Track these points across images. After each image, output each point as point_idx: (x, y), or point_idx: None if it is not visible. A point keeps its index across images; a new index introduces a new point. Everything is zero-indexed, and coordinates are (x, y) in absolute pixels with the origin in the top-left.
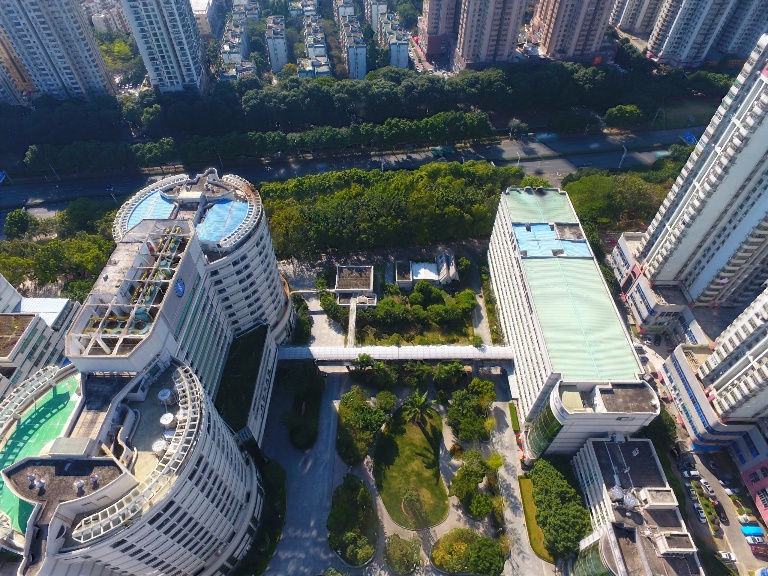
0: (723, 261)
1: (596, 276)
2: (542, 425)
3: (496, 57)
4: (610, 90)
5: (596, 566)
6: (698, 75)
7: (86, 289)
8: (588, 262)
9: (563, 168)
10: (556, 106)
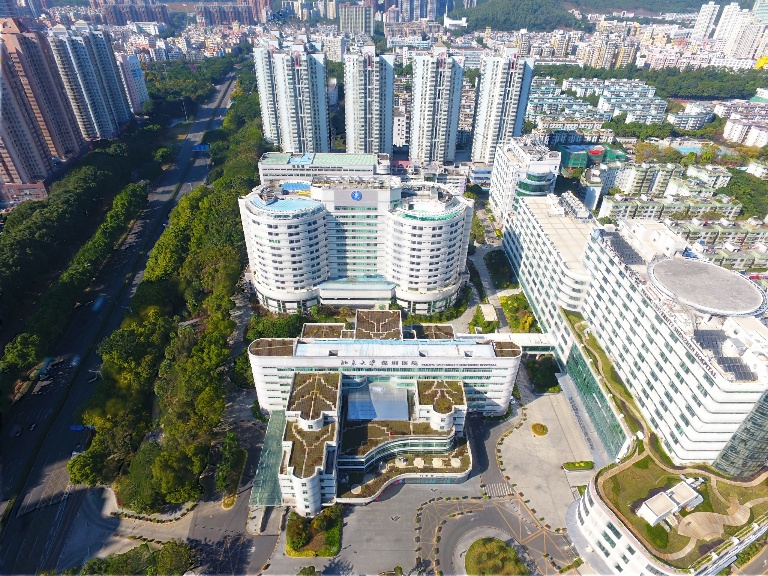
0: (325, 134)
1: None
2: None
3: (52, 169)
4: (133, 152)
5: None
6: (140, 131)
7: (247, 359)
8: None
9: (193, 185)
10: (125, 174)
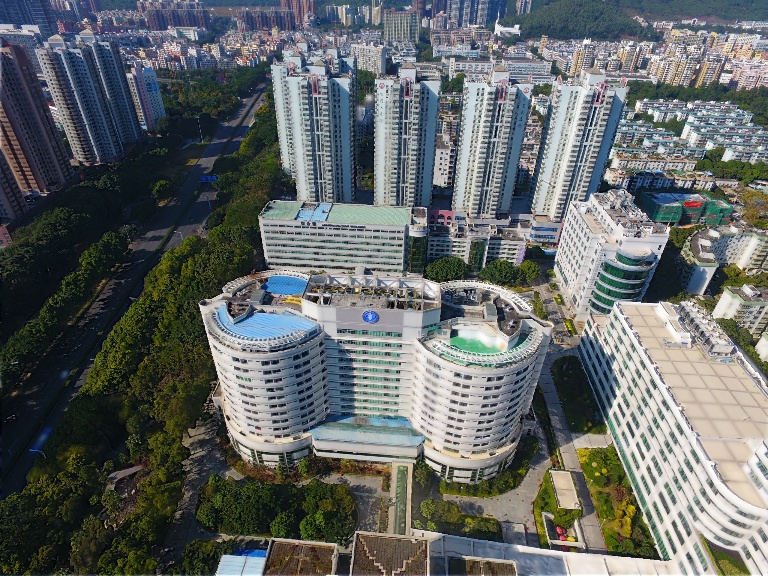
0: (349, 176)
1: (346, 206)
2: (418, 252)
3: (22, 209)
4: (128, 184)
5: (479, 250)
6: (145, 156)
7: (184, 575)
8: (335, 206)
9: (189, 230)
10: (113, 212)
